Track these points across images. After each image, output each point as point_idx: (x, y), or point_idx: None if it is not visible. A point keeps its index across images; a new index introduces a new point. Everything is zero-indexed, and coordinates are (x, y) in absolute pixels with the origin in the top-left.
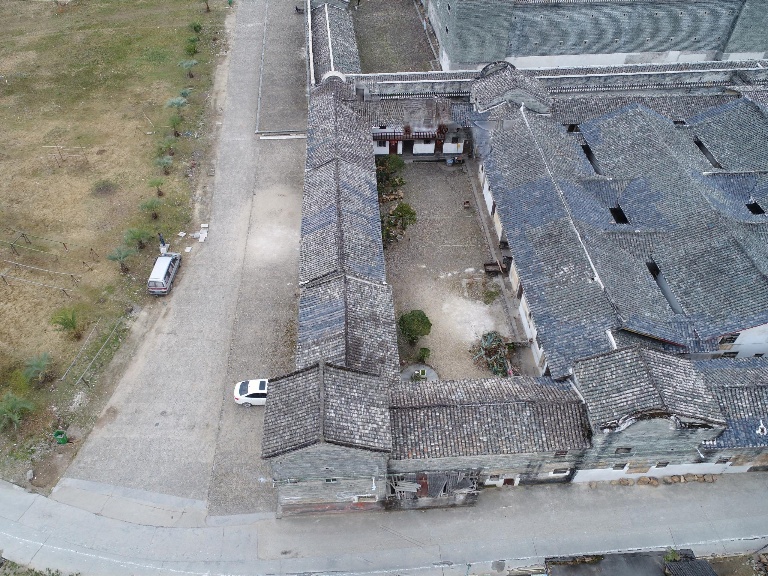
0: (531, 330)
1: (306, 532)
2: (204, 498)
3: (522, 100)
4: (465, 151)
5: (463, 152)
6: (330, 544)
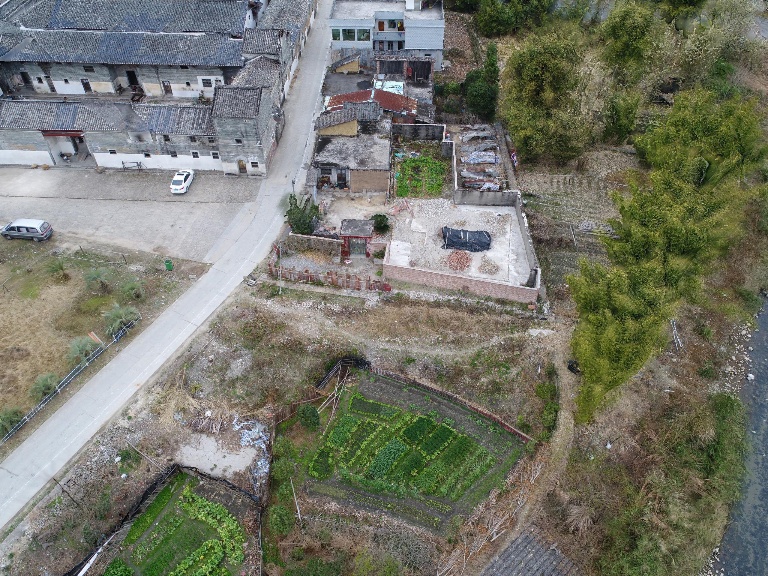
0: (196, 89)
1: (278, 170)
2: (243, 204)
3: (7, 30)
4: (3, 92)
5: (3, 93)
6: (287, 163)
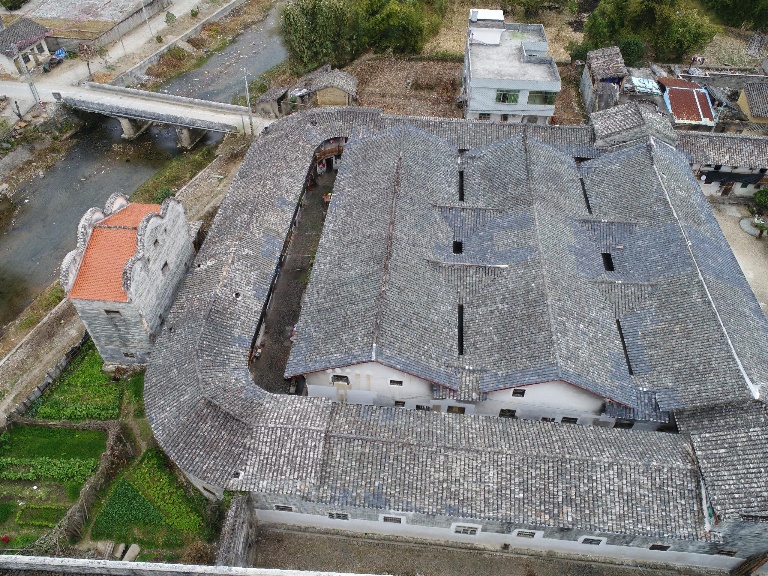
0: None
1: None
2: None
3: None
4: None
5: None
6: None
